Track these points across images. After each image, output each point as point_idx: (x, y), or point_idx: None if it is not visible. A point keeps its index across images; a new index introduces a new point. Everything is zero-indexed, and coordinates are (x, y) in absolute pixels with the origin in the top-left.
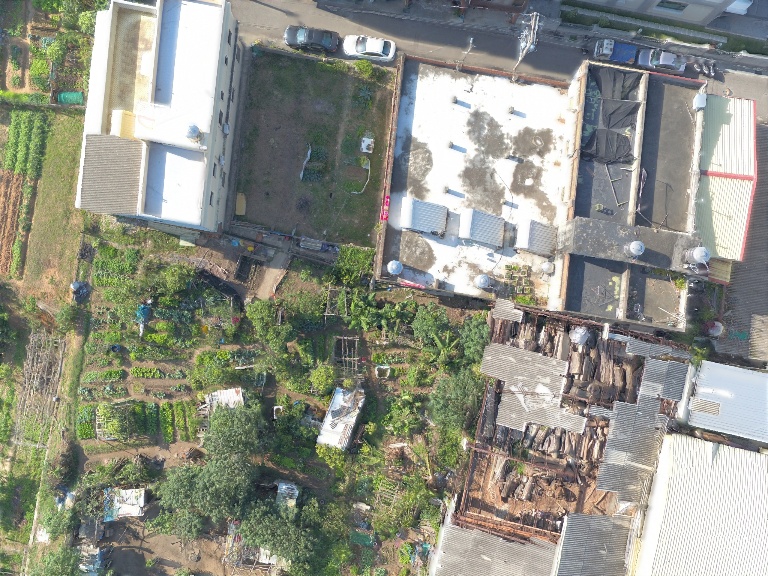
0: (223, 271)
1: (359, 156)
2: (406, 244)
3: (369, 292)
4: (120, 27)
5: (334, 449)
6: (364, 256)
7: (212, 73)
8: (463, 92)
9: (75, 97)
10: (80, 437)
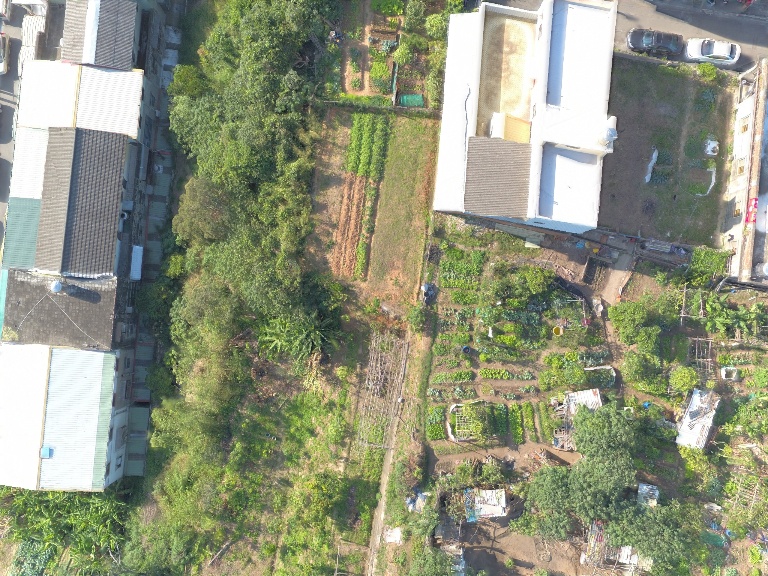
0: (569, 273)
1: (703, 158)
2: None
3: (713, 293)
4: (485, 30)
5: (697, 450)
6: (718, 258)
7: (605, 76)
8: None
9: (415, 99)
10: (431, 438)
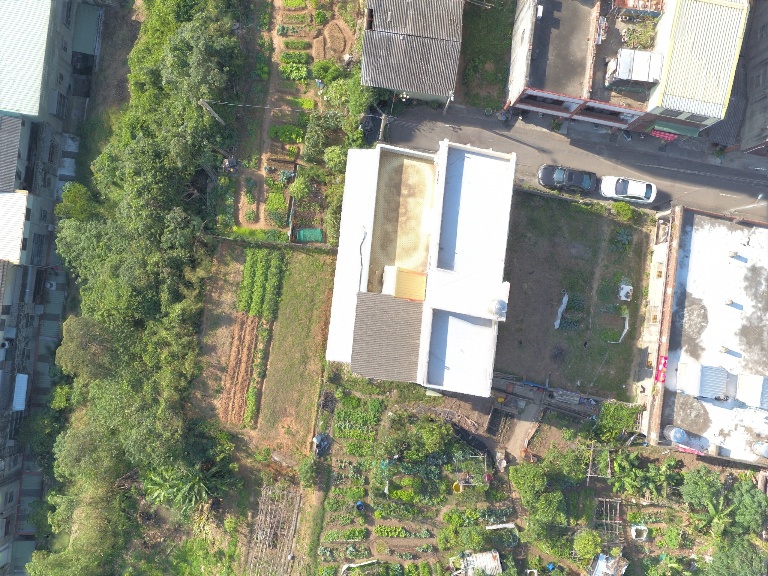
0: (472, 423)
1: (616, 303)
2: (681, 406)
3: (624, 447)
4: (382, 171)
5: None
6: (628, 414)
7: (501, 234)
8: (739, 245)
9: (313, 234)
10: None
